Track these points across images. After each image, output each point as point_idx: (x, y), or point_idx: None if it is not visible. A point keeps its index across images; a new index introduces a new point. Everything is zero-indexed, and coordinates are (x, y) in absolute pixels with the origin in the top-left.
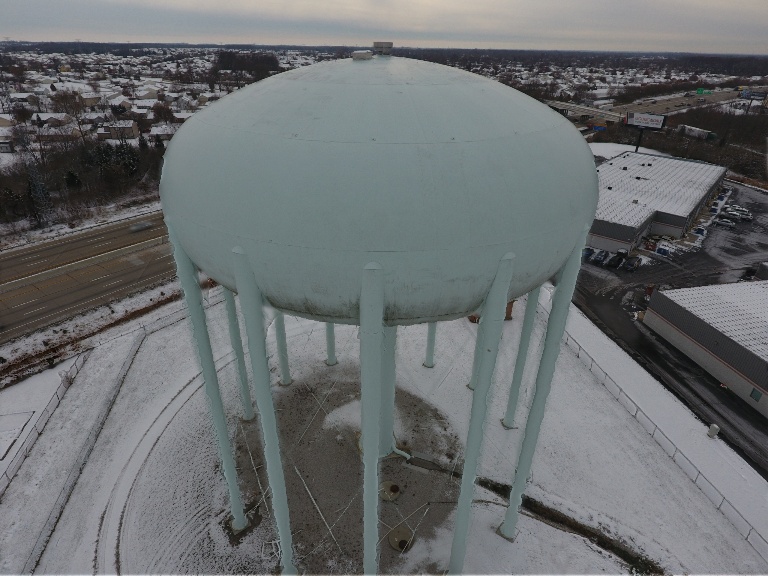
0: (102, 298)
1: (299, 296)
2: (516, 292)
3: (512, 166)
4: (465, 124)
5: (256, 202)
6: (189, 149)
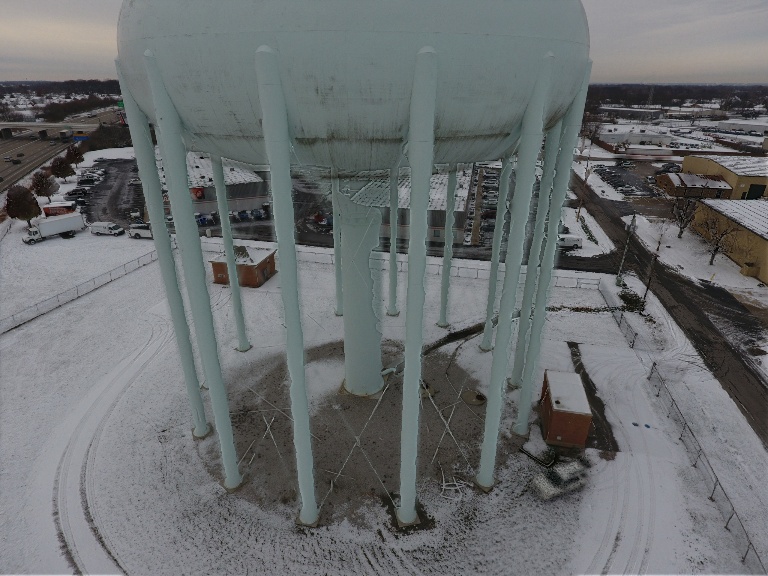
0: None
1: (560, 102)
2: None
3: None
4: None
5: (544, 5)
6: None
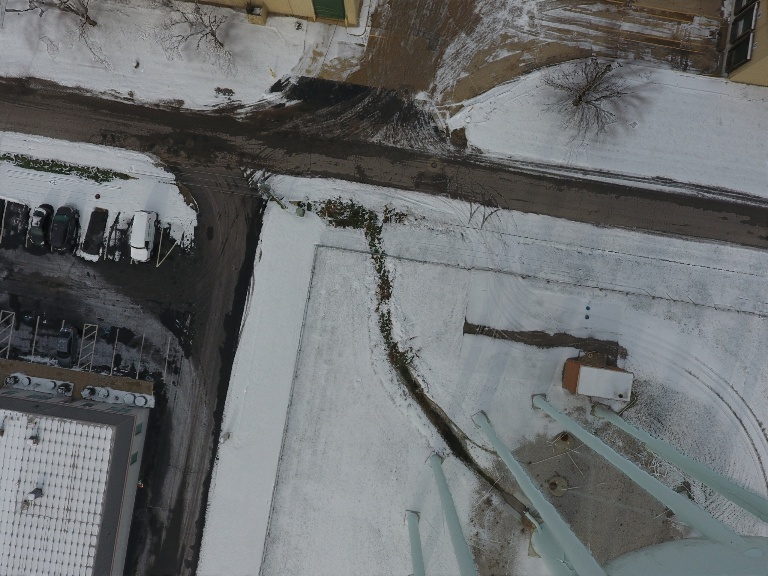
0: None
1: None
2: None
3: None
4: None
5: None
6: None
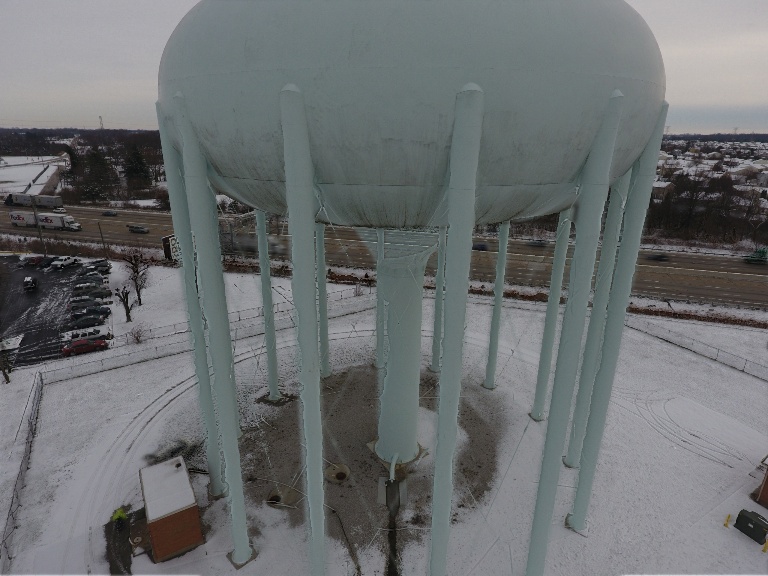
0: None
1: None
2: (222, 162)
3: (212, 1)
4: None
5: None
6: None
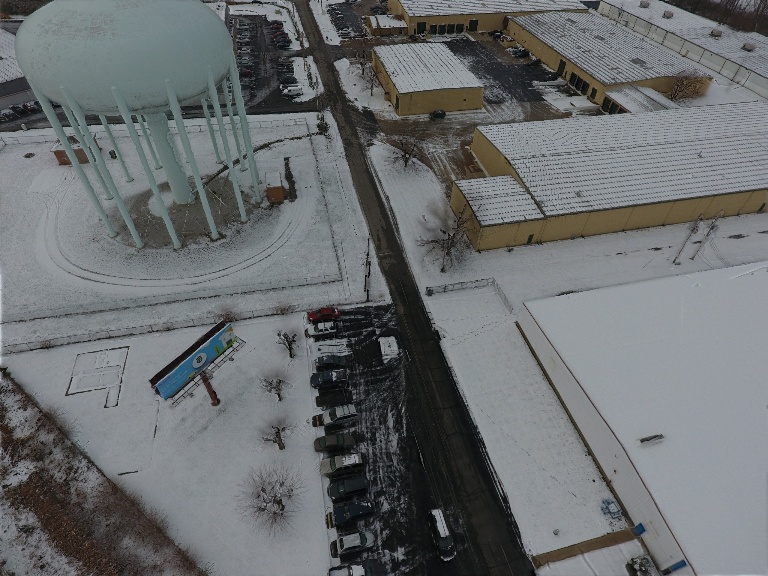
0: None
1: None
2: None
3: None
4: (196, 2)
5: (202, 48)
6: (154, 48)
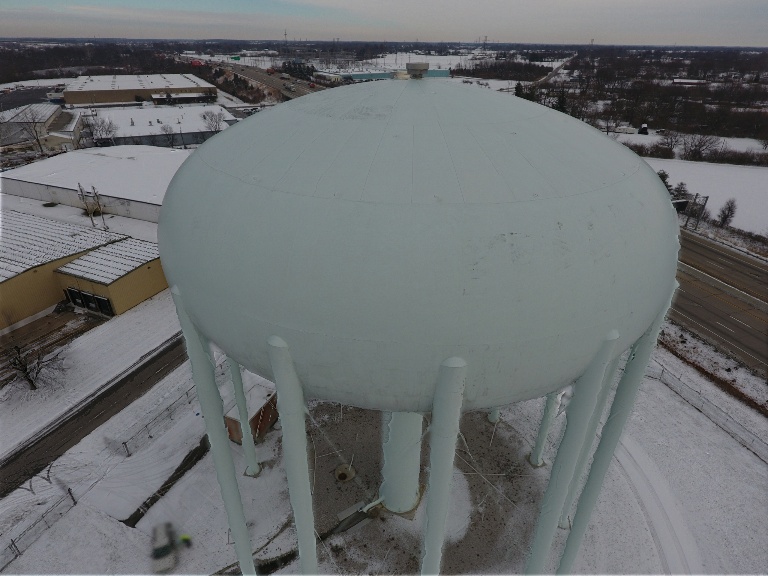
0: (762, 364)
1: None
2: None
3: None
4: None
5: None
6: None
